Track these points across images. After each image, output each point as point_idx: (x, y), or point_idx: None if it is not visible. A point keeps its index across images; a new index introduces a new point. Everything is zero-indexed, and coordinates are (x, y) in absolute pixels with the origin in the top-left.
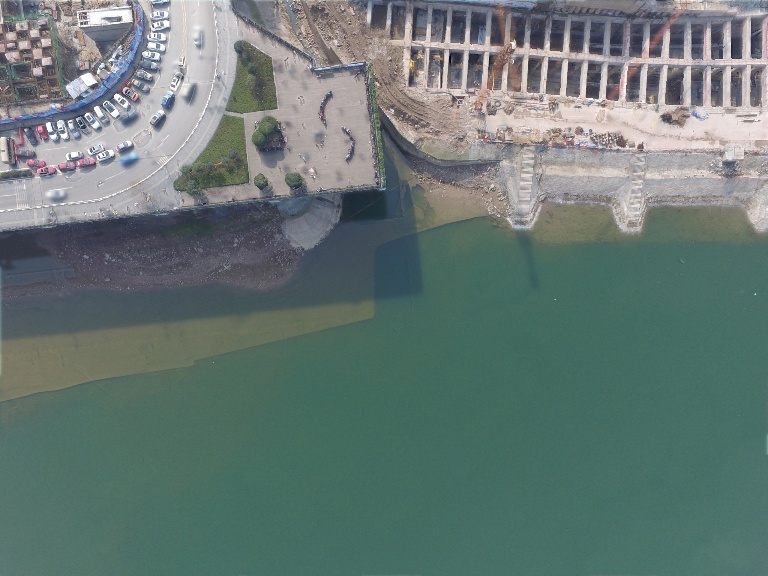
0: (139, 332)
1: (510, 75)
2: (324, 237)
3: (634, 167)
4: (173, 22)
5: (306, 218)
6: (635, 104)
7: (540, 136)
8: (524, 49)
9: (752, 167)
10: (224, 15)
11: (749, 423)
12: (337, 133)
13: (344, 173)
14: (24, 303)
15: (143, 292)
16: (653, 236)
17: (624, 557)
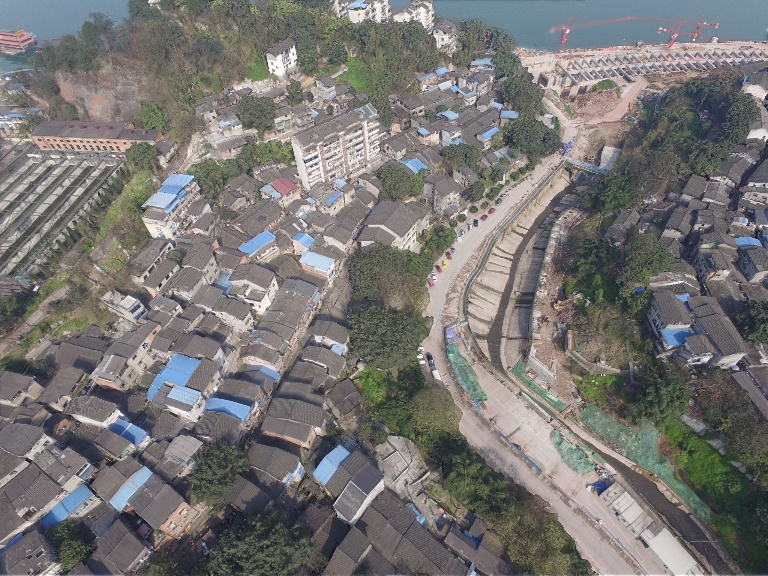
0: None
1: None
2: None
3: None
4: None
5: None
6: (767, 50)
7: None
8: None
9: None
10: None
11: None
12: None
13: None
14: None
15: None
16: None
17: None
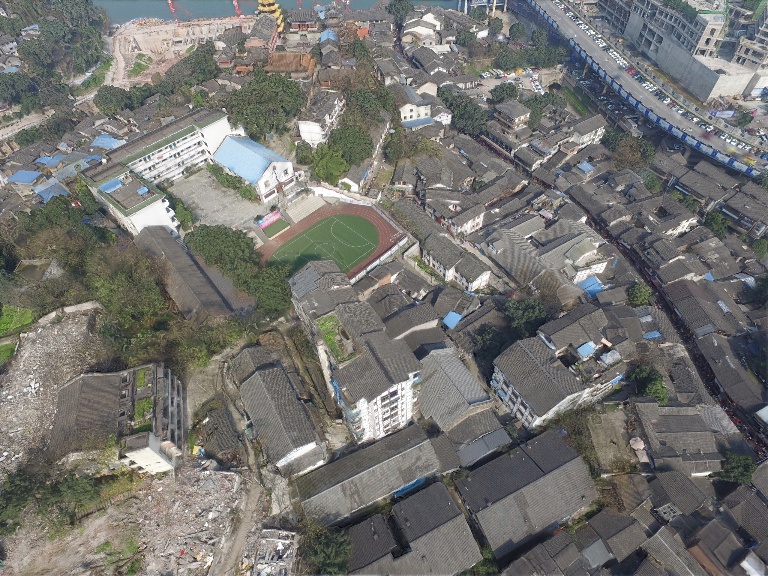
0: None
1: None
2: None
3: None
4: None
5: None
6: None
7: None
8: None
9: None
10: None
11: None
12: None
13: None
14: None
15: None
16: None
17: None
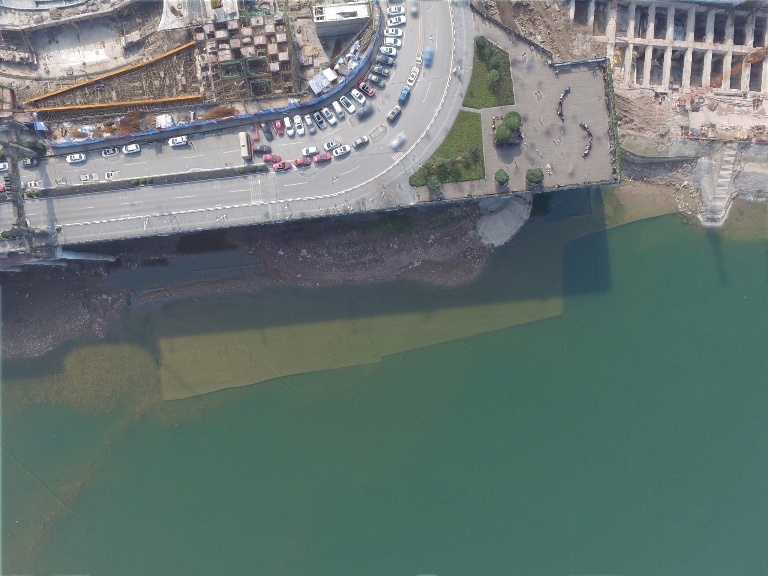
0: (327, 328)
1: (695, 72)
2: (514, 234)
3: None
4: (409, 17)
5: (503, 214)
6: None
7: (745, 133)
8: (728, 45)
9: None
10: (460, 10)
11: None
12: (574, 129)
13: (580, 169)
14: (213, 299)
15: (332, 288)
16: None
17: None
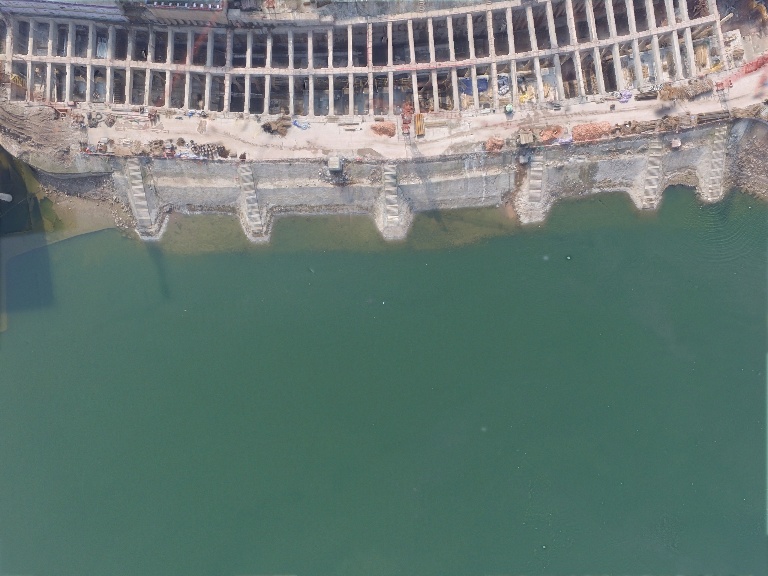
0: None
1: None
2: None
3: (241, 177)
4: None
5: None
6: (237, 114)
7: (139, 148)
8: (124, 61)
9: (363, 175)
10: None
11: (384, 432)
12: None
13: None
14: None
15: None
16: (285, 245)
17: (266, 567)
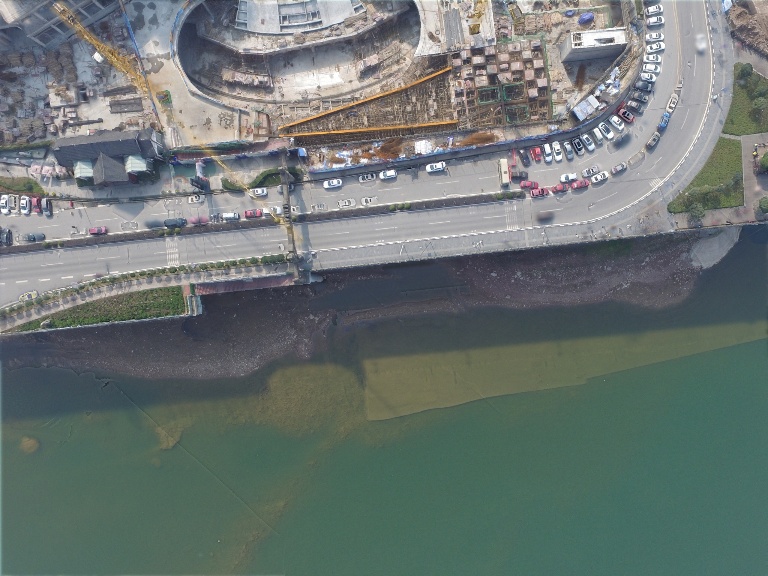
0: (532, 350)
1: None
2: (724, 256)
3: None
4: (667, 43)
5: (720, 237)
6: None
7: None
8: None
9: None
10: (720, 37)
11: None
12: None
13: None
14: (419, 319)
15: (538, 310)
16: None
17: None
